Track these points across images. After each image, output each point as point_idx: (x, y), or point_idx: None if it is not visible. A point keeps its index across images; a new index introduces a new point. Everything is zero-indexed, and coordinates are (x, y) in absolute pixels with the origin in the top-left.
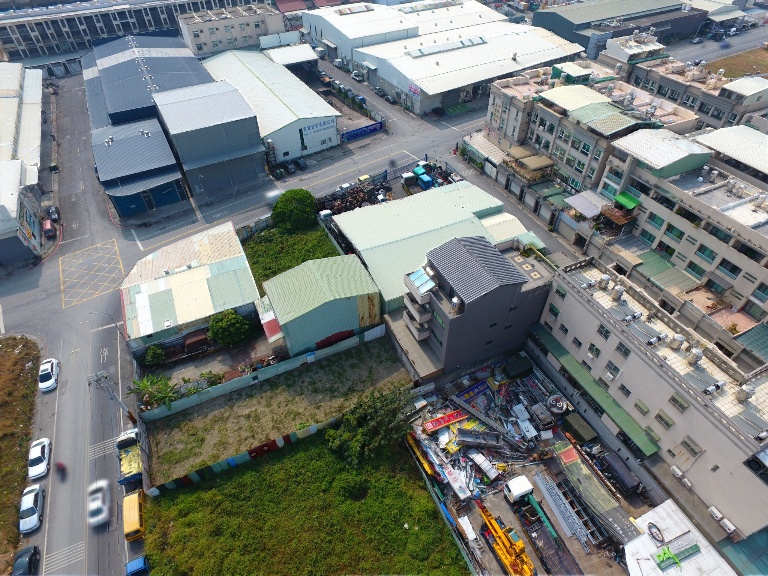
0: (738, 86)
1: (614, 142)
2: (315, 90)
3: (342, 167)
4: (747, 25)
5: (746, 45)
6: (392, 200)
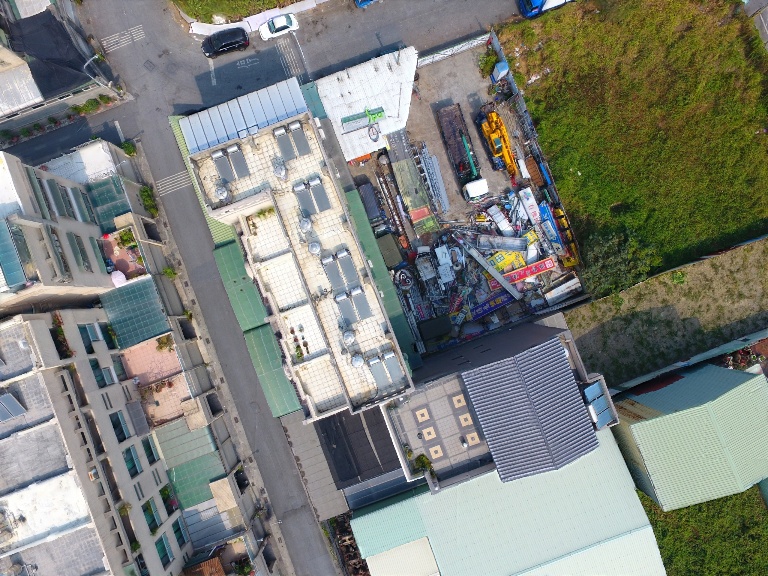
0: None
1: None
2: None
3: None
4: None
5: None
6: None
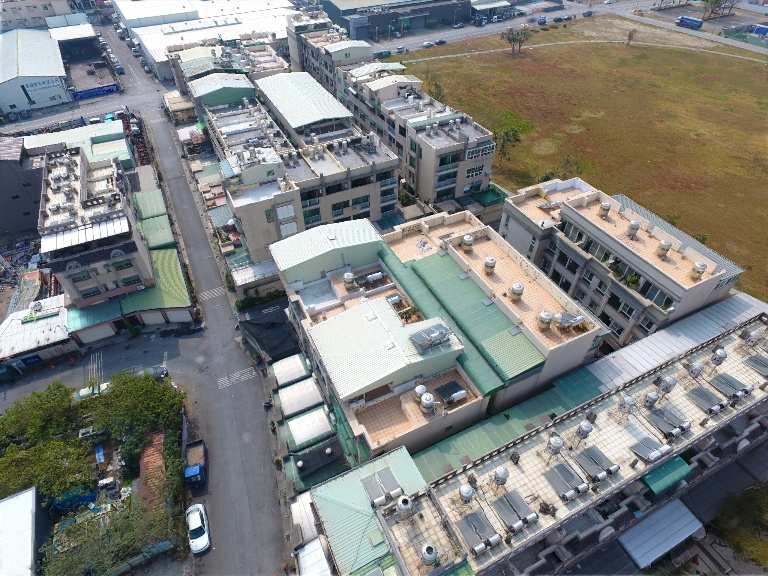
0: (333, 46)
1: (190, 82)
2: (90, 62)
3: (59, 117)
4: (513, 14)
5: (497, 29)
6: (50, 133)
